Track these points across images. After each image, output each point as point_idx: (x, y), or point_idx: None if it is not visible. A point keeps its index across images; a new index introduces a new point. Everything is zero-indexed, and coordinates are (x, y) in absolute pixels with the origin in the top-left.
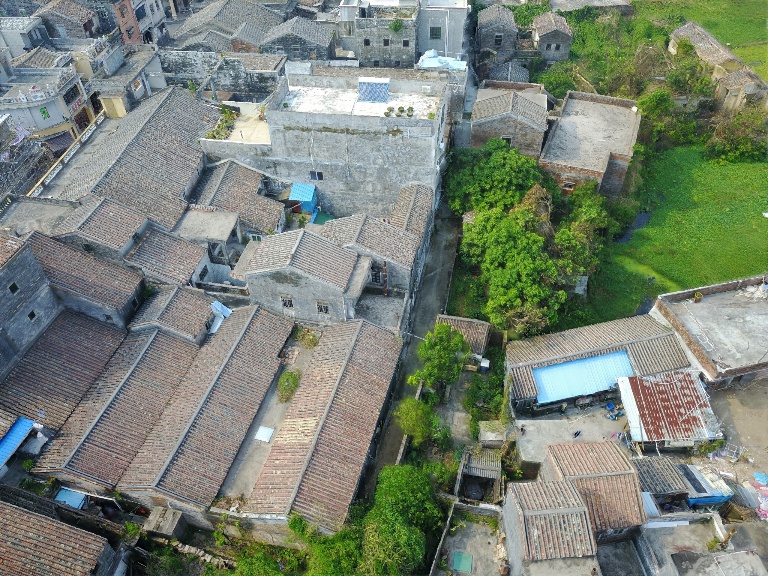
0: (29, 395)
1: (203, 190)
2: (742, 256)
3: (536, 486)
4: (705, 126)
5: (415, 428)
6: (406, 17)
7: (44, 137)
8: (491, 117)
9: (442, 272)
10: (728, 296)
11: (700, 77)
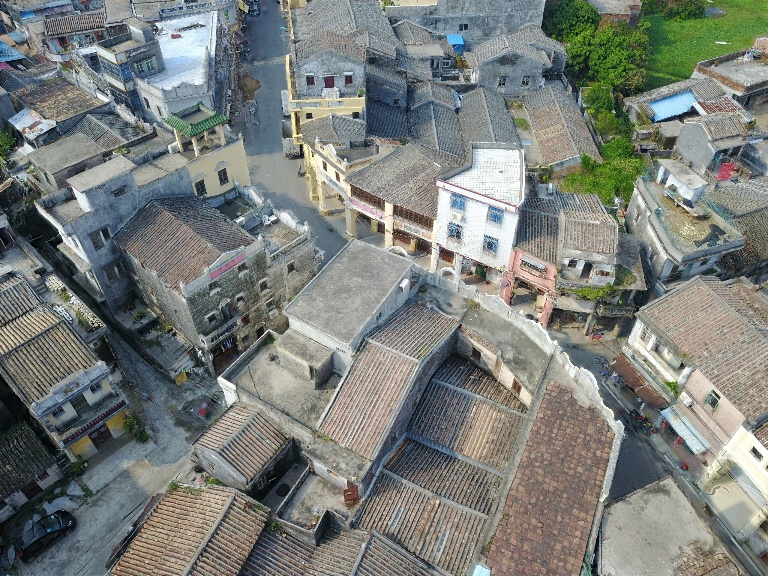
0: (384, 137)
1: (399, 38)
2: None
3: (699, 118)
4: (658, 2)
5: (613, 122)
6: None
7: None
8: None
9: None
10: (730, 63)
11: None
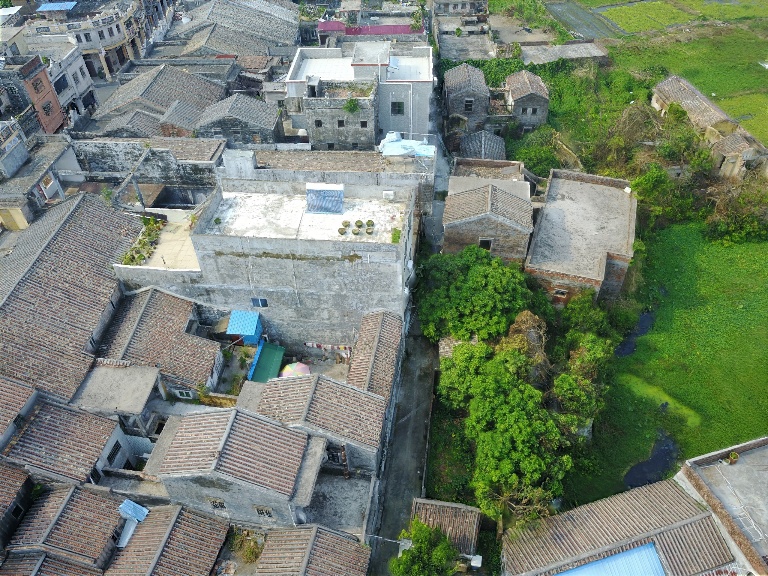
0: None
1: (117, 332)
2: (765, 370)
3: None
4: (702, 198)
5: None
6: (363, 93)
7: None
8: (467, 218)
9: (417, 416)
10: None
11: (697, 149)
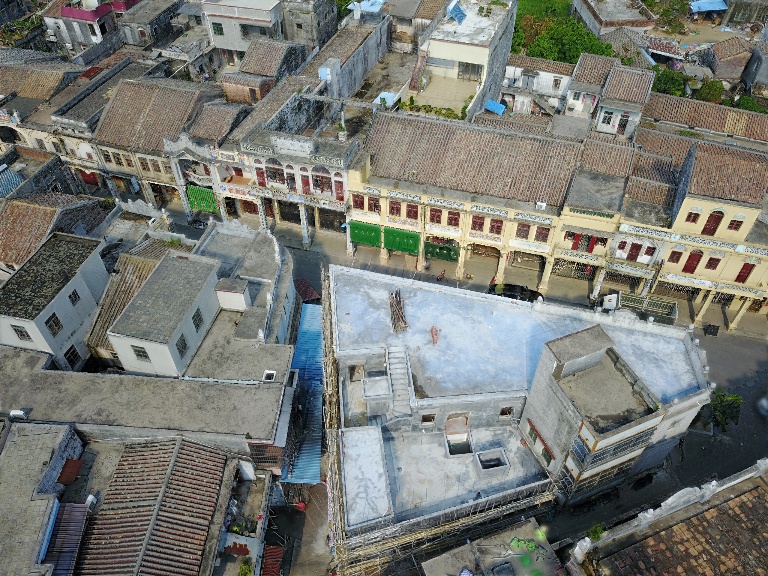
0: None
1: None
2: None
3: (766, 49)
4: None
5: None
6: None
7: (295, 298)
8: None
9: None
10: None
11: None
